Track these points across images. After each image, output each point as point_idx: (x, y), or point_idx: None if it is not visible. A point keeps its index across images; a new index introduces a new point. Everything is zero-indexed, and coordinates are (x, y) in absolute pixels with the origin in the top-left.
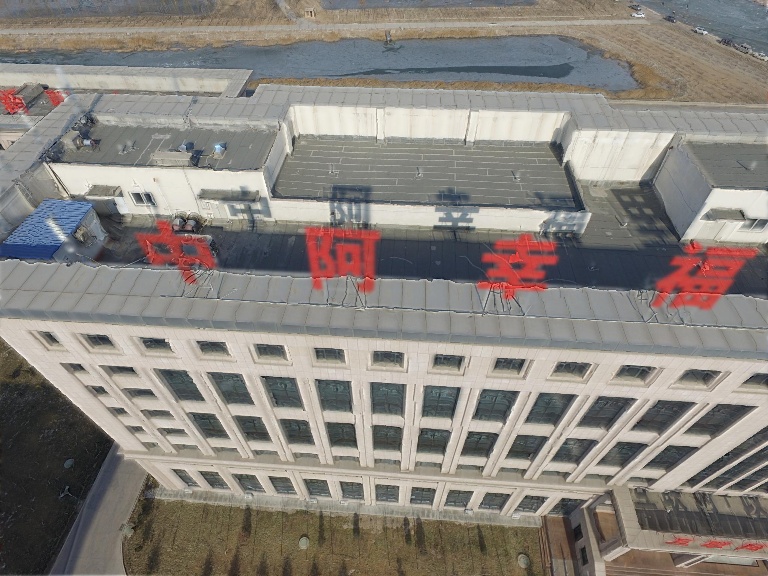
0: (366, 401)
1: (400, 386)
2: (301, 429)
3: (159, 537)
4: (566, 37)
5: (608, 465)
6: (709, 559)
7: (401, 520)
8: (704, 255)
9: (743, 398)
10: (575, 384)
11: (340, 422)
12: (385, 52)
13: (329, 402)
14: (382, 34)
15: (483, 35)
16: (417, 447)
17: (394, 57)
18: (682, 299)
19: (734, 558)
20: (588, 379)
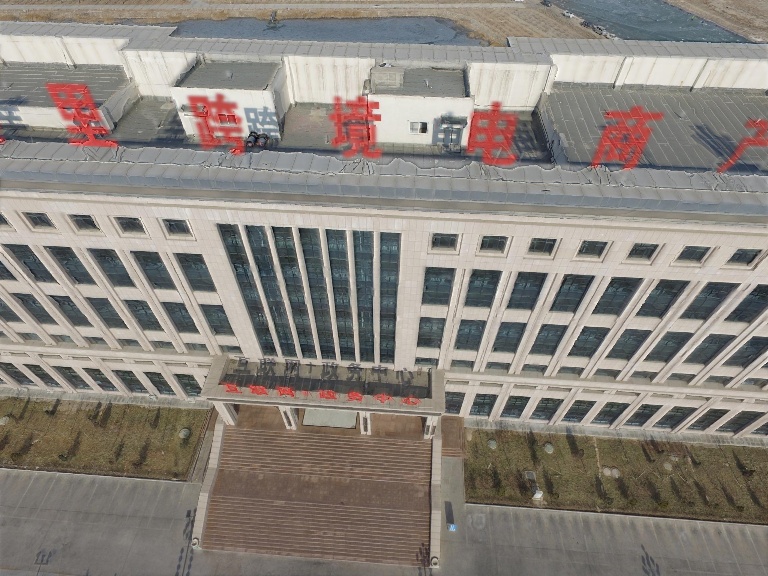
0: None
1: None
2: None
3: None
4: (443, 19)
5: (192, 332)
6: (317, 424)
7: (95, 404)
8: (196, 145)
9: (181, 245)
10: (56, 235)
11: None
12: (266, 30)
13: None
14: (268, 14)
15: (365, 16)
16: (36, 318)
17: (272, 35)
18: (30, 145)
19: (338, 423)
20: (58, 229)
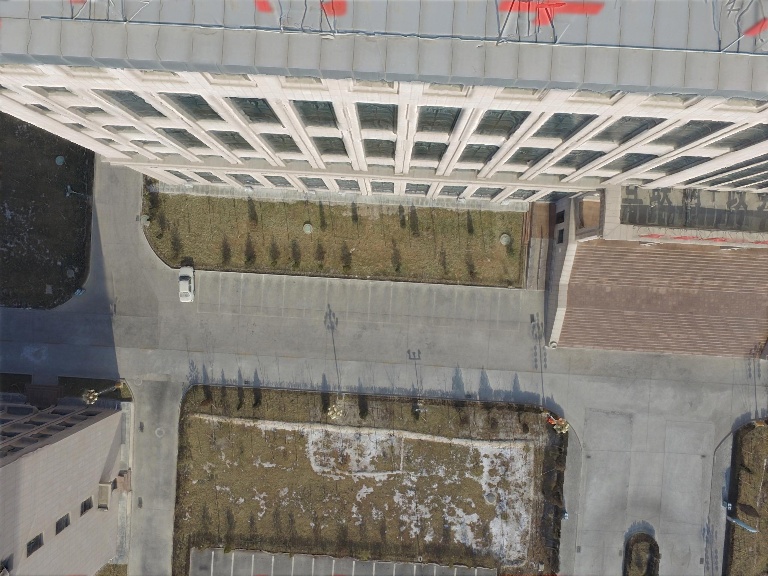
0: (352, 119)
1: (390, 105)
2: (285, 140)
3: (175, 226)
4: None
5: (608, 169)
6: None
7: (396, 208)
8: None
9: None
10: (599, 105)
11: (326, 136)
12: None
13: (310, 118)
14: None
15: None
16: (411, 155)
17: None
18: None
19: None
20: (616, 100)
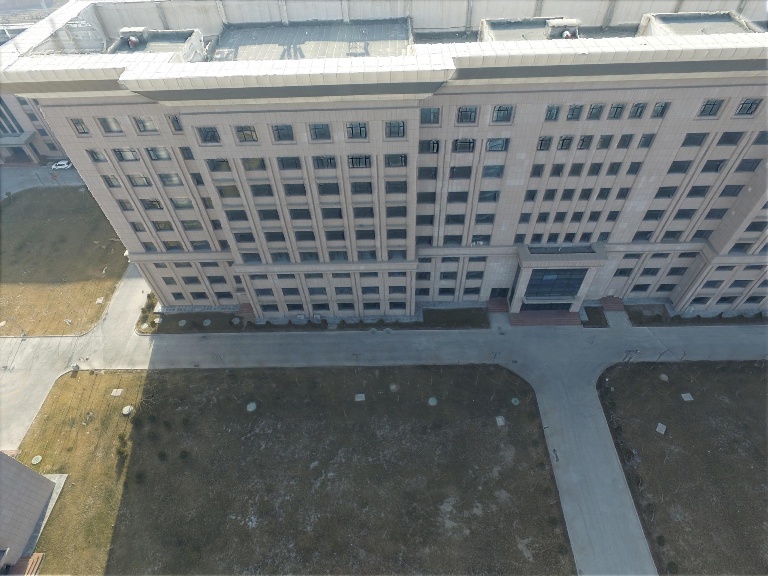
0: None
1: None
2: None
3: None
4: None
5: None
6: None
7: None
8: None
9: None
10: None
11: None
12: None
13: None
14: None
15: None
16: None
17: None
18: None
19: None
20: None
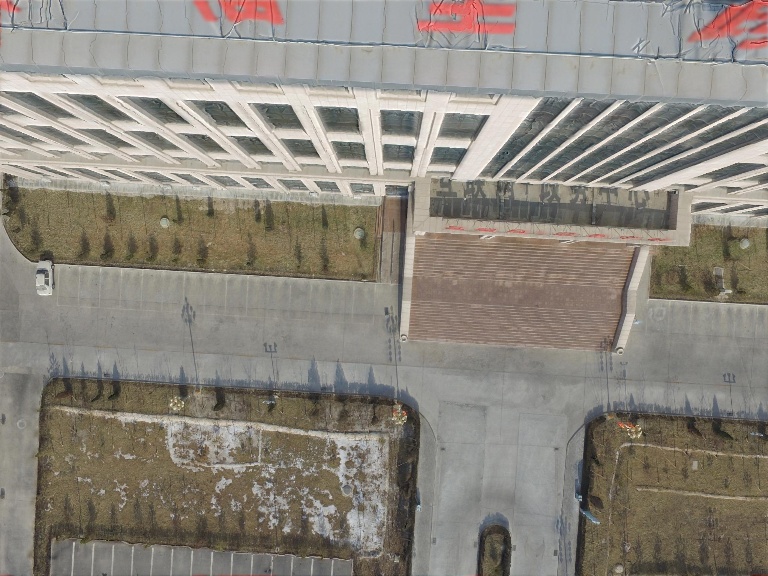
0: None
1: None
2: None
3: (34, 220)
4: None
5: (399, 161)
6: None
7: (252, 202)
8: None
9: (466, 108)
10: (274, 94)
11: (90, 128)
12: None
13: (52, 110)
14: None
15: None
16: (201, 148)
17: None
18: None
19: None
20: None
